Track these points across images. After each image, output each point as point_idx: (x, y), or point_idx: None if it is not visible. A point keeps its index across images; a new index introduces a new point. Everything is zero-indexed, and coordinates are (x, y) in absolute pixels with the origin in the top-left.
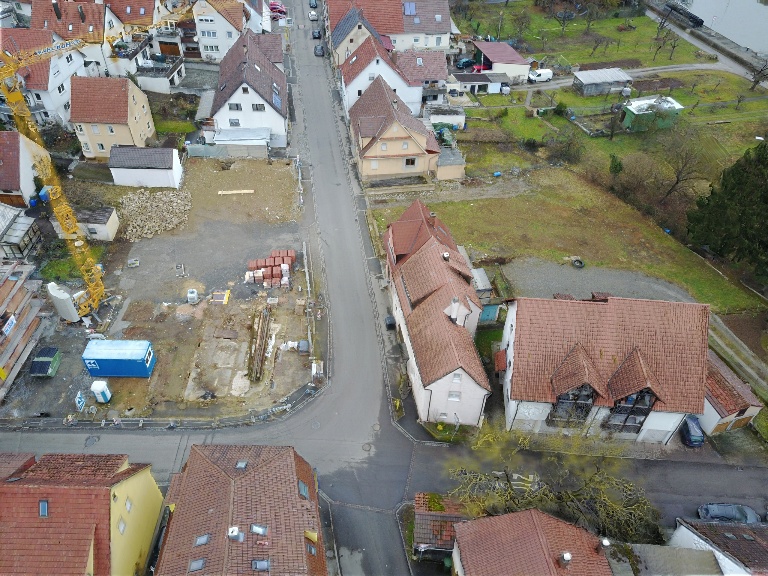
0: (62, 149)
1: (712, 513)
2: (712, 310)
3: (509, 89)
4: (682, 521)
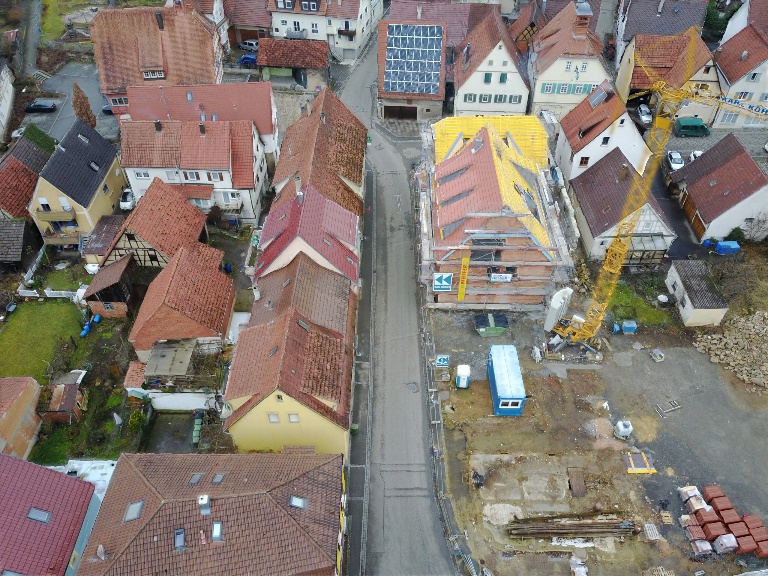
0: None
1: None
2: None
3: None
4: None
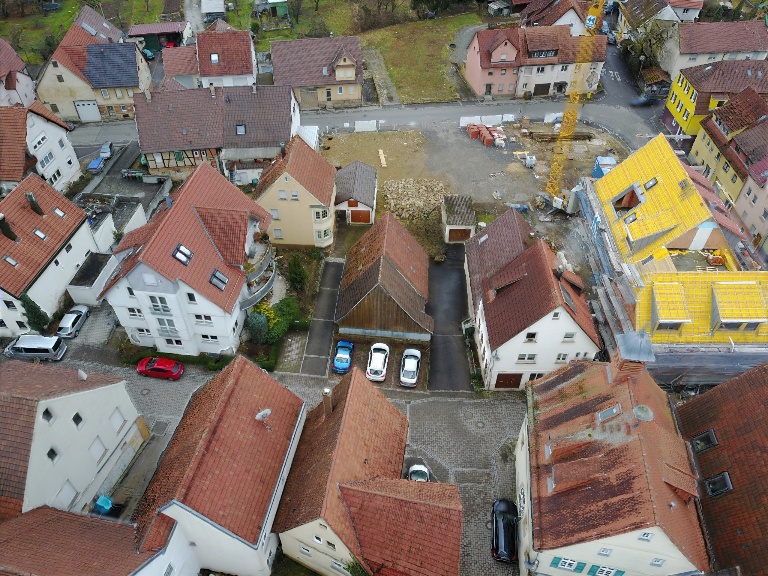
0: (310, 267)
1: (613, 38)
2: (482, 23)
3: None
4: None
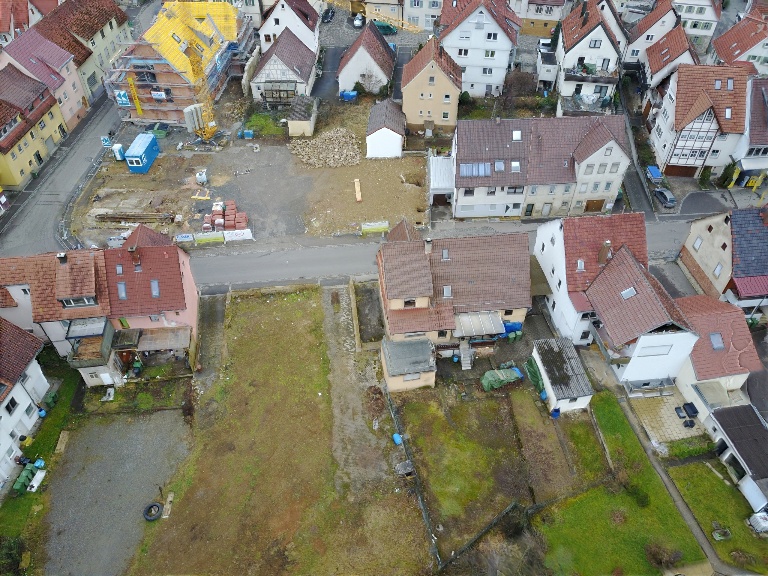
0: None
1: None
2: None
3: (762, 526)
4: None
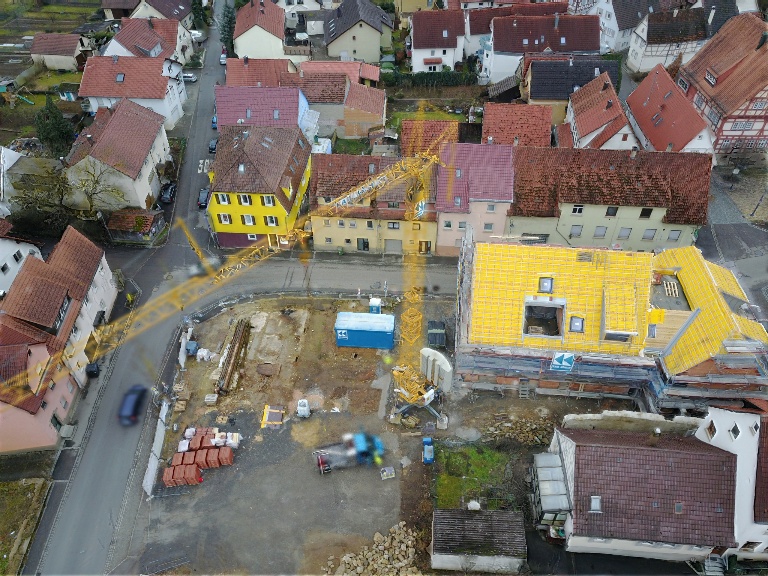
0: None
1: None
2: None
3: None
4: (1, 197)
